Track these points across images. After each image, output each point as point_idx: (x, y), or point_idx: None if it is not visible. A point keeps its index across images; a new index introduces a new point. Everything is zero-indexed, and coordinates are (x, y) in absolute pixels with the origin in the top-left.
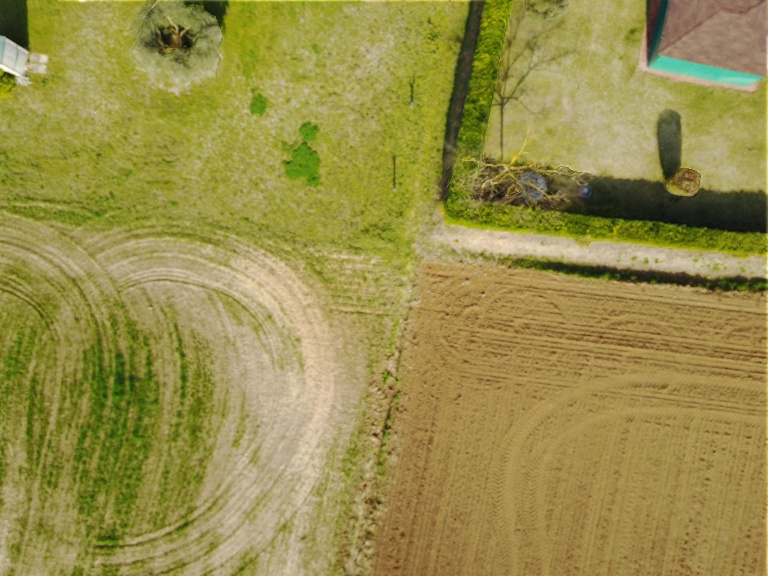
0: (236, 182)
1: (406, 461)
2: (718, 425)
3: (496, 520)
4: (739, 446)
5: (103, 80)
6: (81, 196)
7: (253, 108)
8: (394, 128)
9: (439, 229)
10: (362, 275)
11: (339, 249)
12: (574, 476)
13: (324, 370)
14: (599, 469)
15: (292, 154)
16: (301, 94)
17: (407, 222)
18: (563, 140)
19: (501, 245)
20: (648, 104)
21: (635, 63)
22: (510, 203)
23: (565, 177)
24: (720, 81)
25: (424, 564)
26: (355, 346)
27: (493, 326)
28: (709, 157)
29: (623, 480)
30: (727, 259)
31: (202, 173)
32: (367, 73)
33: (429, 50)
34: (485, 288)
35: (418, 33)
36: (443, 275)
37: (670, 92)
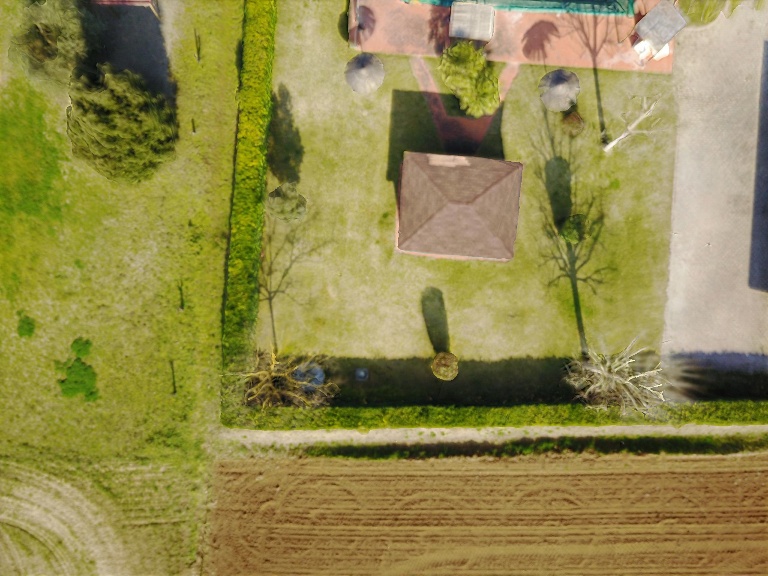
0: (11, 408)
1: None
2: None
3: None
4: None
5: None
6: None
7: (20, 331)
8: (168, 332)
9: (226, 427)
10: (152, 485)
11: (125, 462)
12: None
13: None
14: None
15: (66, 372)
16: (69, 310)
17: (192, 425)
18: (333, 327)
19: (289, 436)
20: (409, 284)
21: (392, 245)
22: (280, 405)
23: (340, 363)
24: None
25: None
26: (153, 559)
27: (290, 520)
28: (475, 329)
29: None
30: None
31: None
32: (134, 281)
33: (193, 252)
34: (279, 481)
35: (180, 236)
36: (237, 472)
37: (429, 270)
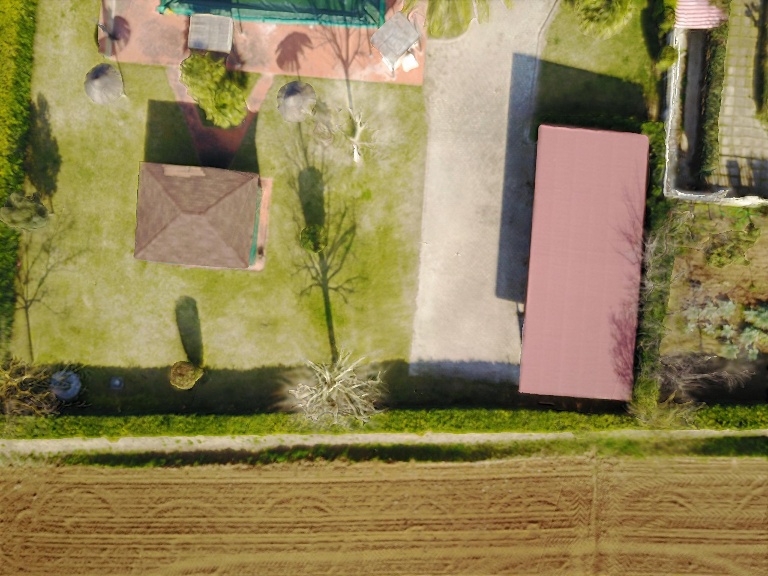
0: None
1: None
2: None
3: None
4: None
5: None
6: None
7: None
8: None
9: None
10: None
11: None
12: None
13: None
14: None
15: None
16: None
17: None
18: (89, 336)
19: (46, 444)
20: (164, 293)
21: None
22: (21, 414)
23: (95, 372)
24: None
25: None
26: None
27: (45, 529)
28: (228, 337)
29: None
30: None
31: None
32: None
33: None
34: (37, 489)
35: None
36: None
37: (183, 279)
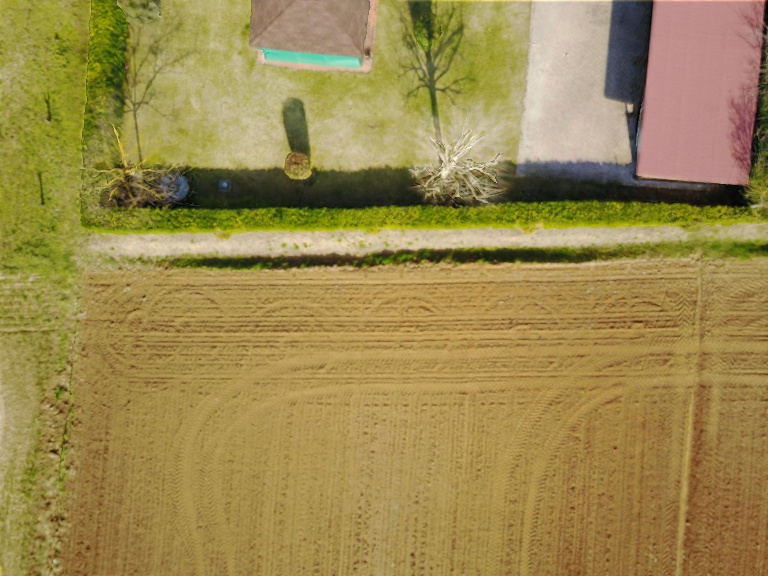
0: None
1: (84, 473)
2: (376, 397)
3: (178, 520)
4: (398, 415)
5: None
6: None
7: None
8: (35, 145)
9: (94, 239)
10: (22, 294)
11: None
12: (247, 466)
13: None
14: (270, 456)
15: None
16: None
17: (60, 236)
18: (197, 138)
19: (155, 248)
20: (271, 95)
21: (254, 56)
22: (136, 206)
23: (204, 174)
24: (332, 65)
25: (112, 574)
26: (23, 365)
27: (156, 328)
28: (335, 139)
29: (293, 463)
30: (367, 235)
31: None
32: (1, 94)
33: (59, 65)
34: (146, 292)
35: (47, 49)
36: (106, 284)
37: (290, 81)
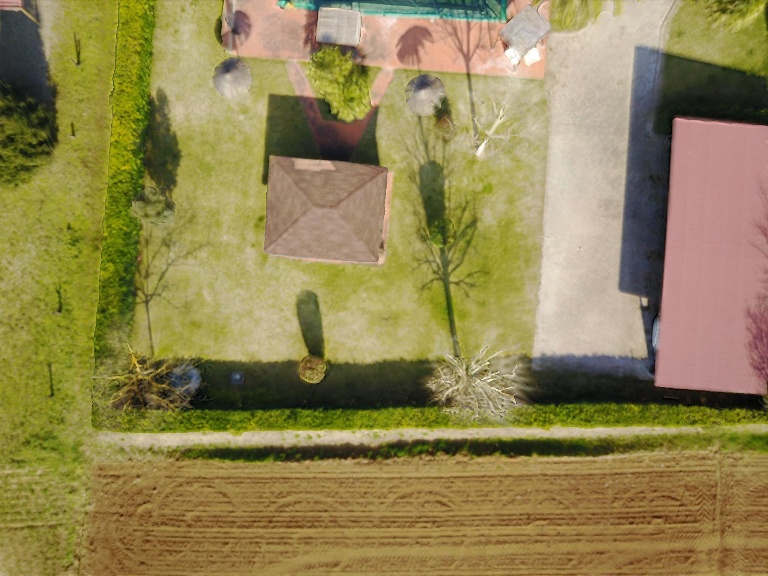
0: None
1: None
2: None
3: None
4: None
5: None
6: None
7: None
8: (46, 335)
9: None
10: (29, 487)
11: (2, 465)
12: None
13: None
14: None
15: None
16: None
17: (70, 427)
18: (209, 330)
19: (166, 439)
20: (285, 287)
21: None
22: (149, 408)
23: (216, 366)
24: None
25: None
26: (29, 562)
27: (166, 523)
28: (349, 332)
29: None
30: None
31: None
32: (11, 284)
33: (71, 255)
34: (156, 484)
35: (59, 239)
36: (115, 474)
37: (304, 273)
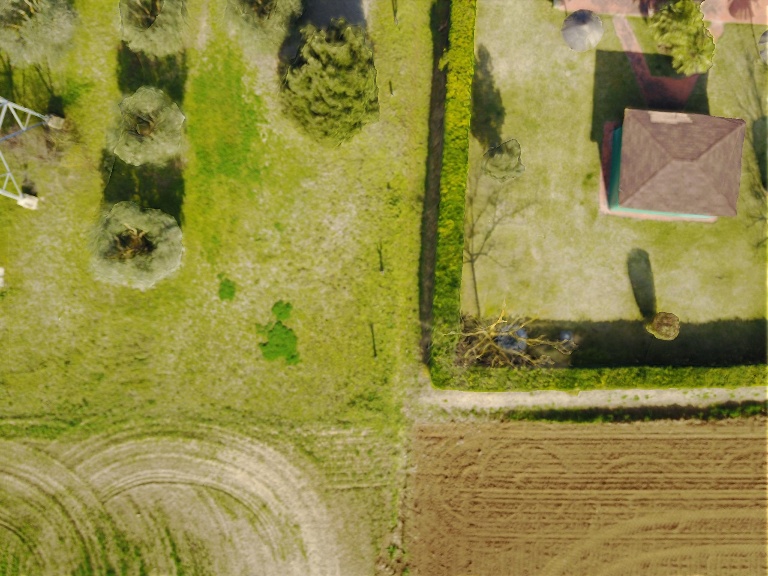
0: (213, 371)
1: None
2: (734, 559)
3: None
4: None
5: (64, 285)
6: (53, 407)
7: (222, 294)
8: (367, 296)
9: (426, 391)
10: (354, 449)
11: (327, 425)
12: None
13: (327, 554)
14: None
15: (267, 335)
16: (269, 274)
17: (393, 388)
18: (537, 290)
19: (490, 400)
20: (615, 245)
21: (596, 207)
22: (495, 366)
23: (545, 326)
24: (681, 217)
25: None
26: (356, 523)
27: (494, 484)
28: (682, 290)
29: None
30: (716, 388)
31: (177, 367)
32: (333, 245)
33: (392, 215)
34: (480, 445)
35: (379, 199)
36: (436, 436)
37: (635, 231)
